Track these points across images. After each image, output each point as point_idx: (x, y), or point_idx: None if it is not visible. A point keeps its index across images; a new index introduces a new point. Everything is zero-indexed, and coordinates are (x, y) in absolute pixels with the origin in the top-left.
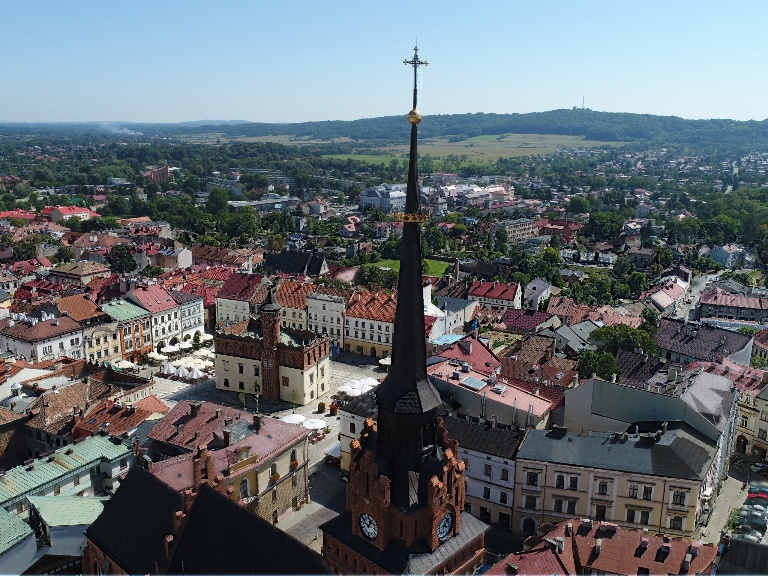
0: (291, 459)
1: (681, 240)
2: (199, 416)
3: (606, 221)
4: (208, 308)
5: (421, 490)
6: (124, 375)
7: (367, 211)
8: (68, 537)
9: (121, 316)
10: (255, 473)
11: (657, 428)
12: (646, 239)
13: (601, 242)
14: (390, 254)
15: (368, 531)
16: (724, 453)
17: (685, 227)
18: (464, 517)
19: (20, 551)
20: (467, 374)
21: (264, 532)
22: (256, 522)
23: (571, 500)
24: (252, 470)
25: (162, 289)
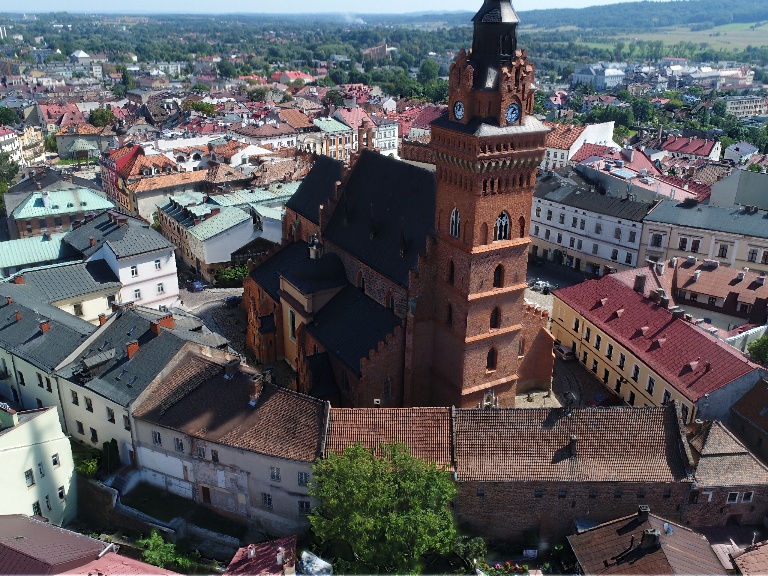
0: None
1: None
2: None
3: None
4: None
5: (496, 82)
6: None
7: (577, 88)
8: (275, 228)
9: (328, 129)
10: None
11: None
12: None
13: None
14: None
15: (459, 115)
16: None
17: None
18: (531, 119)
19: (243, 229)
20: None
21: (401, 169)
22: (396, 164)
23: None
24: None
25: (364, 112)
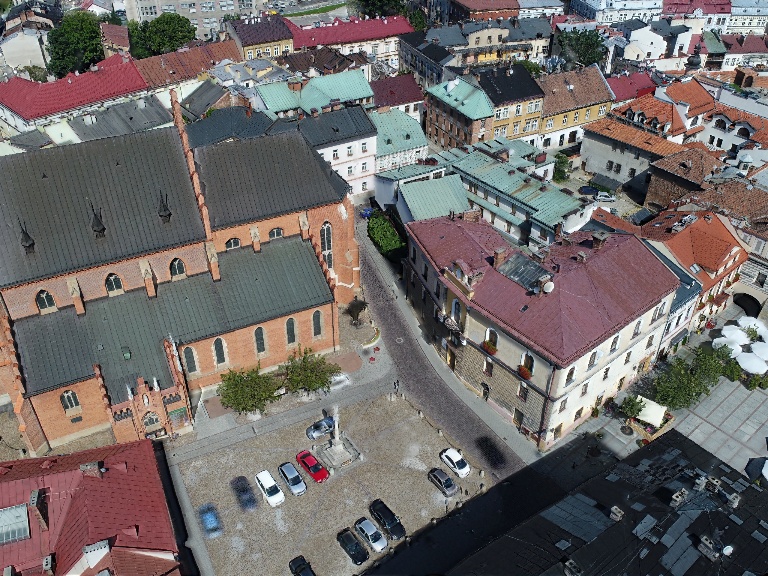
0: (527, 362)
1: None
2: (591, 250)
3: None
4: None
5: None
6: None
7: None
8: None
9: None
10: None
11: None
12: None
13: None
14: None
15: None
16: None
17: None
18: None
19: None
20: None
21: None
22: None
23: None
24: None
25: None
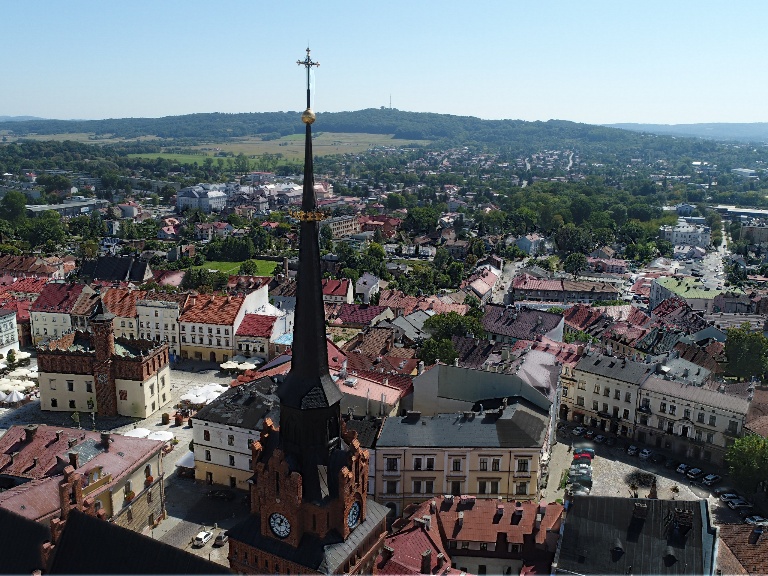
0: (145, 475)
1: (490, 231)
2: (36, 441)
3: (423, 216)
4: (21, 323)
5: (330, 482)
6: None
7: (185, 212)
8: None
9: None
10: (108, 494)
11: (498, 404)
12: (460, 232)
13: (420, 236)
14: (215, 256)
15: (279, 530)
16: (553, 421)
17: (492, 219)
18: (368, 504)
19: None
20: None
21: (150, 550)
22: (140, 541)
23: (429, 480)
24: (105, 491)
25: None
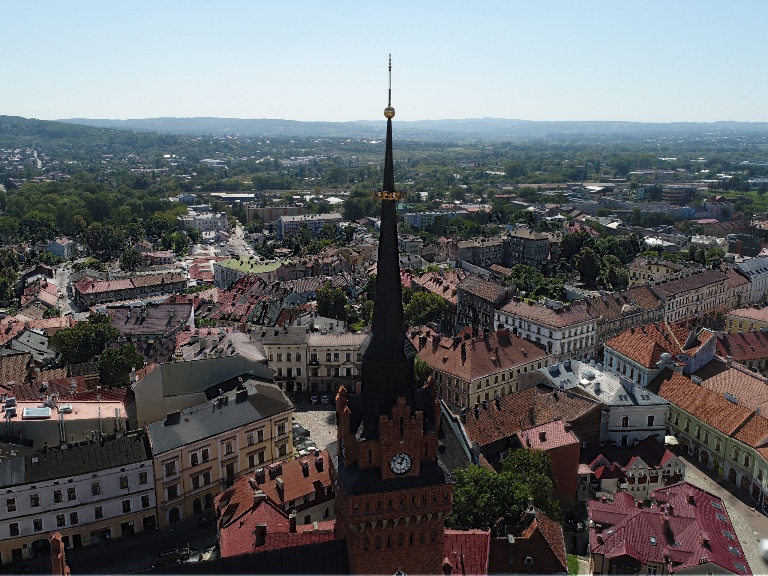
0: None
1: None
2: None
3: None
4: None
5: None
6: None
7: None
8: None
9: None
10: None
11: (231, 386)
12: None
13: None
14: None
15: (400, 469)
16: None
17: (4, 227)
18: None
19: None
20: (17, 408)
21: (199, 574)
22: (181, 572)
23: (205, 472)
24: None
25: None
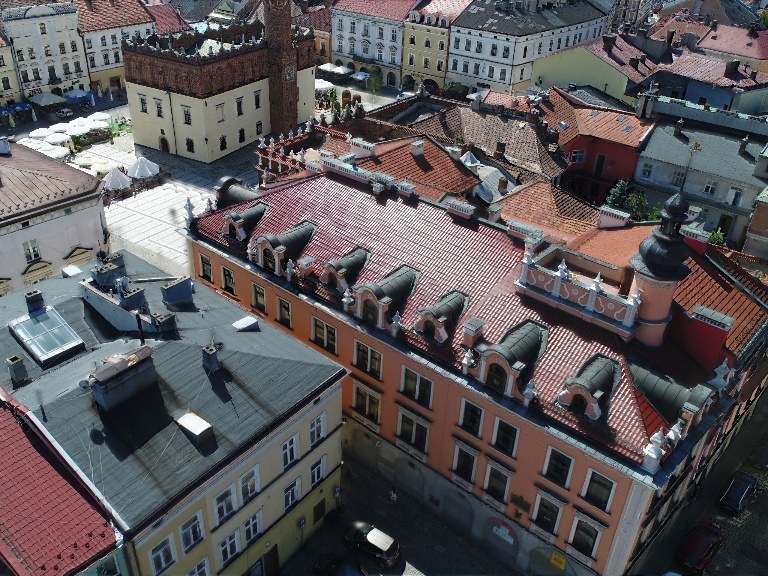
0: None
1: None
2: (612, 50)
3: None
4: None
5: None
6: (383, 111)
7: None
8: None
9: None
10: None
11: None
12: None
13: None
14: None
15: None
16: None
17: None
18: None
19: None
20: None
21: None
22: None
23: None
24: None
25: None
